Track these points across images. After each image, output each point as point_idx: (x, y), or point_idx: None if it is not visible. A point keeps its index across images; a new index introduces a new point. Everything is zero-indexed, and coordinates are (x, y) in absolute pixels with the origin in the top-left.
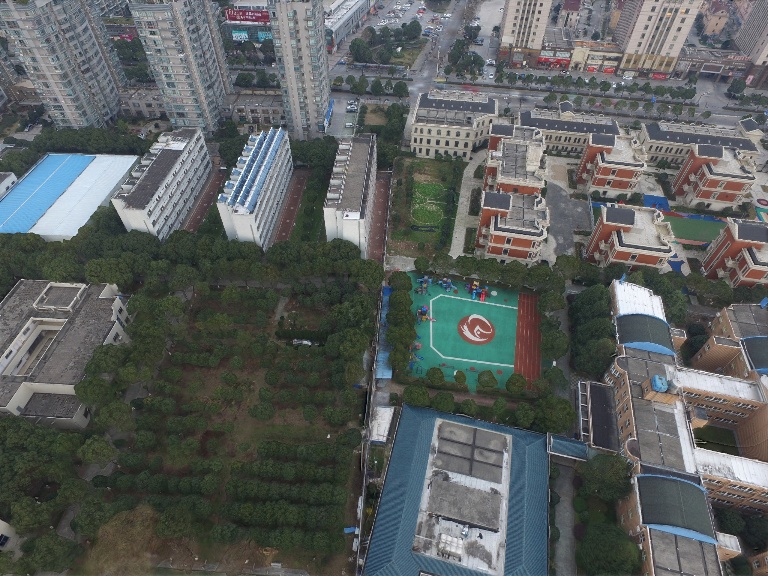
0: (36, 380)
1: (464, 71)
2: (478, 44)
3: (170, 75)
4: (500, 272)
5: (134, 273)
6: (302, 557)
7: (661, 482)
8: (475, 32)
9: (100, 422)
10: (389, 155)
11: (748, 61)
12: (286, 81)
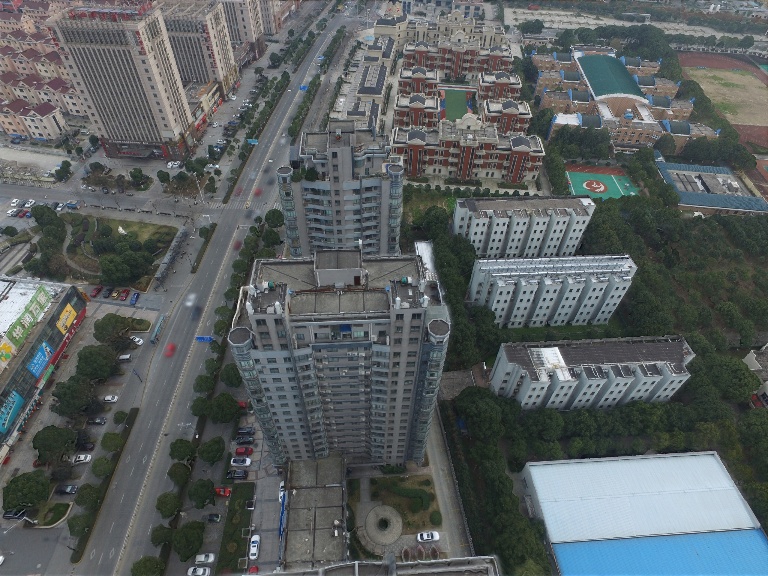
0: None
1: (199, 183)
2: (107, 172)
3: None
4: None
5: None
6: None
7: (672, 126)
8: (97, 162)
9: None
10: (445, 212)
11: (248, 43)
12: None
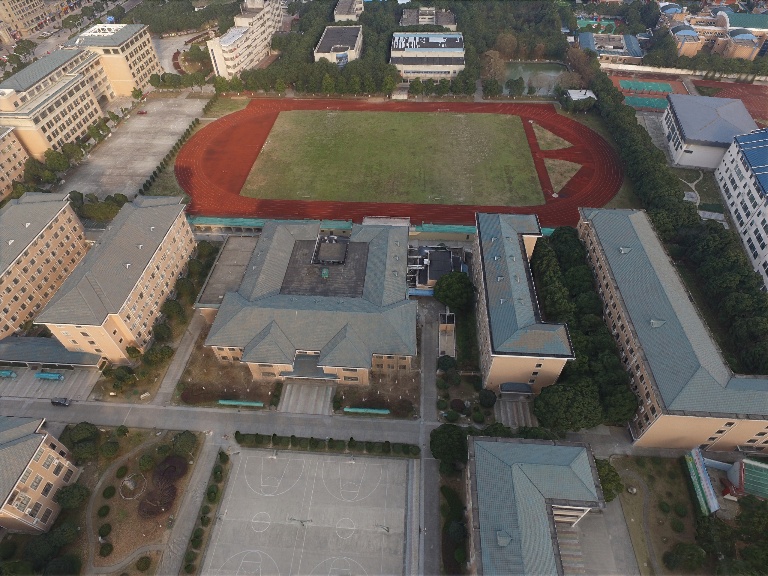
0: None
1: None
2: None
3: None
4: (606, 8)
5: (449, 8)
6: (555, 60)
7: None
8: None
9: (474, 28)
10: None
11: None
12: None
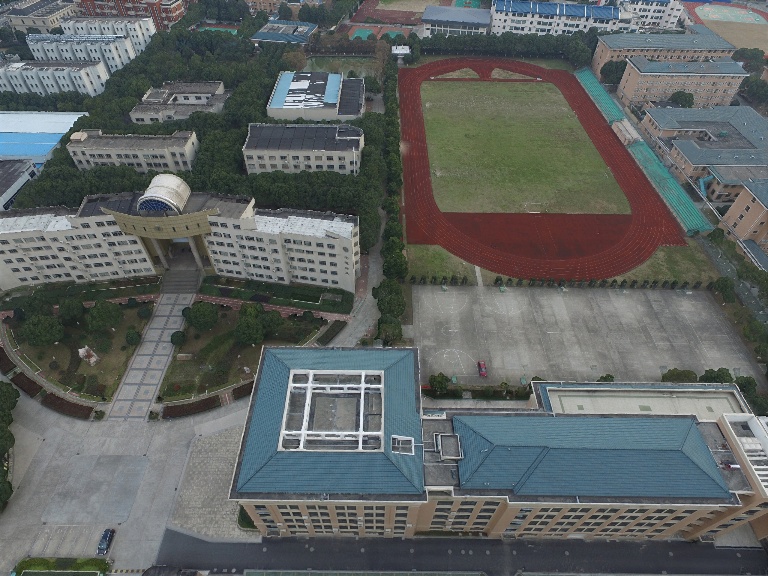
0: None
1: None
2: None
3: None
4: None
5: None
6: None
7: None
8: None
9: (244, 71)
10: None
11: None
12: None
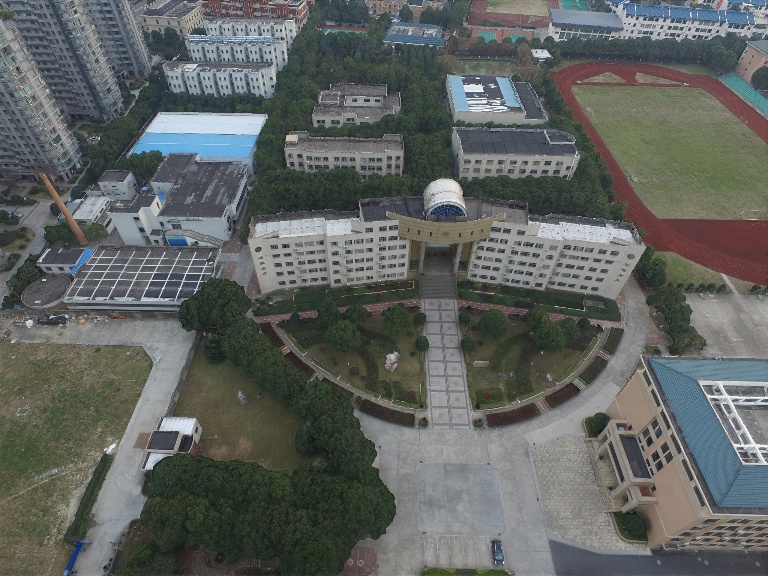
0: (384, 95)
1: None
2: None
3: (94, 51)
4: None
5: None
6: None
7: None
8: None
9: None
10: None
11: None
12: (130, 23)
